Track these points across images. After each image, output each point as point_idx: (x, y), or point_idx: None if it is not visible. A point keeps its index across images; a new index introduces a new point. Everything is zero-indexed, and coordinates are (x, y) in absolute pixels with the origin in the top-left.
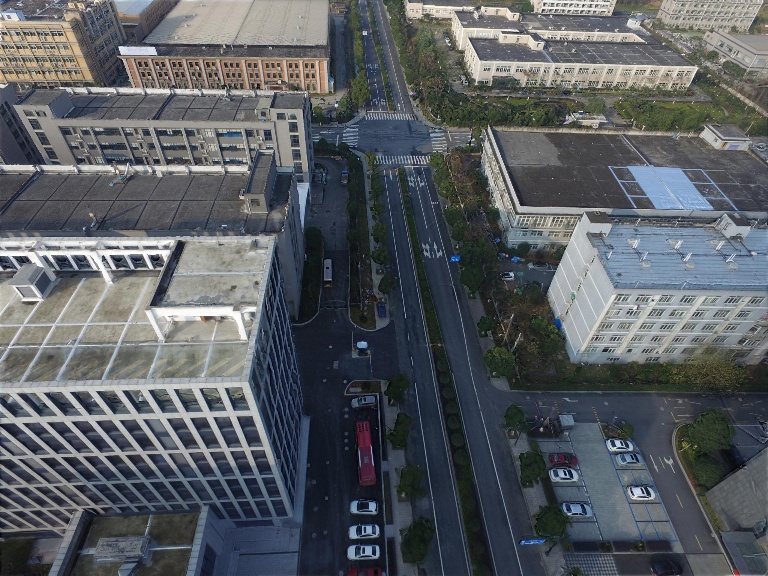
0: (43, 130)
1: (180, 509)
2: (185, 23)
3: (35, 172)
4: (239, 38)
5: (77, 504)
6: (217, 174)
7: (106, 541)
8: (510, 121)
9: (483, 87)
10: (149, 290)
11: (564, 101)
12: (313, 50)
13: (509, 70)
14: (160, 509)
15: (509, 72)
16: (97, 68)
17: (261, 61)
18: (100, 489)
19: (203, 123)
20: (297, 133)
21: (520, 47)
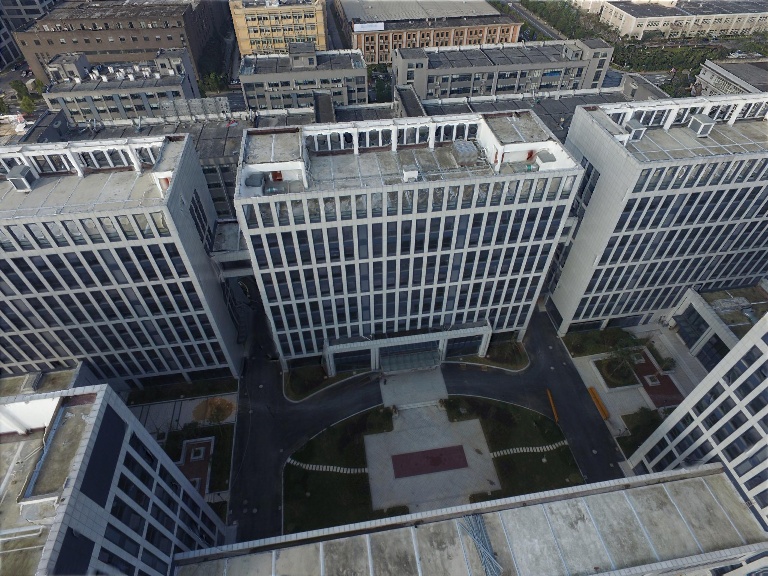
0: (414, 80)
1: (745, 284)
2: (366, 5)
3: (468, 102)
4: (430, 13)
5: (700, 279)
6: (592, 95)
7: (722, 300)
8: (685, 63)
9: (636, 41)
10: (759, 128)
11: (708, 47)
12: (500, 18)
13: (658, 24)
14: (735, 284)
15: (657, 26)
16: (326, 46)
17: (467, 29)
18: (734, 259)
19: (538, 65)
20: (602, 69)
21: (655, 6)
